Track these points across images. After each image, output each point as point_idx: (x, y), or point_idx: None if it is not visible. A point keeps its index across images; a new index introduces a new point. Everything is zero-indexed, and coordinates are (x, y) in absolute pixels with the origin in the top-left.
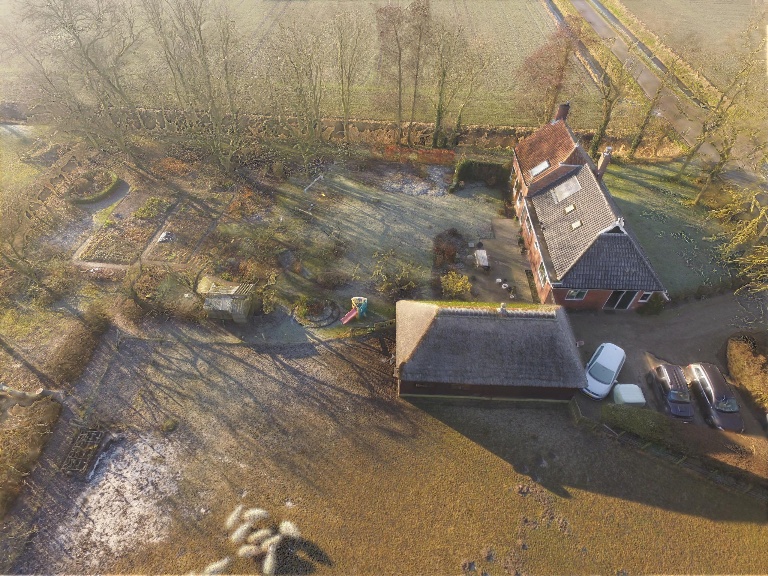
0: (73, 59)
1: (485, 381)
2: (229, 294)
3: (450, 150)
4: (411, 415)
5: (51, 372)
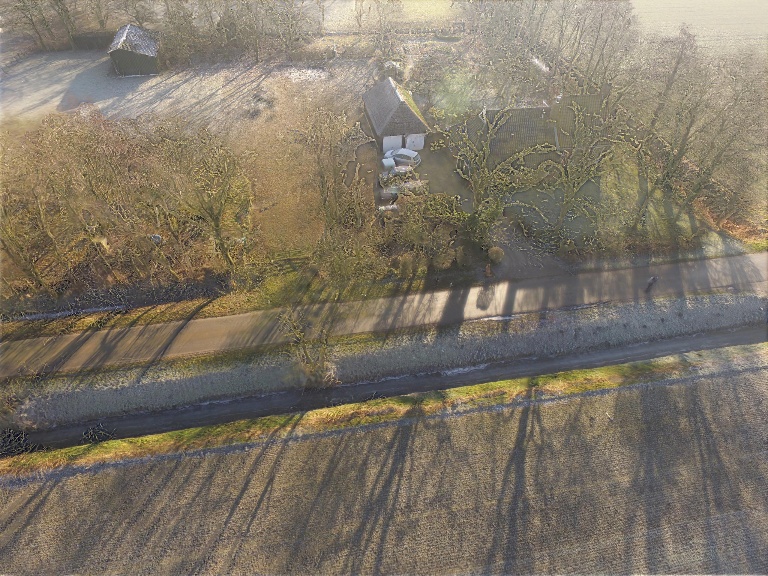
0: None
1: (369, 111)
2: None
3: None
4: None
5: None
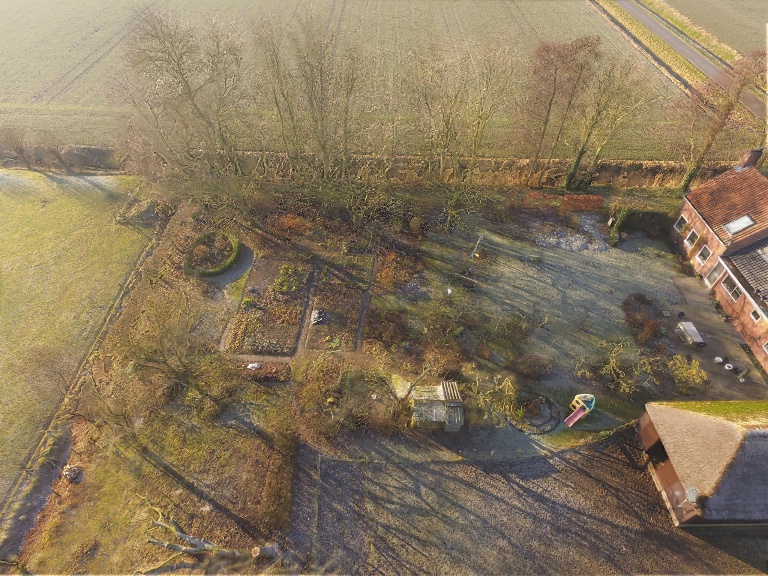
0: (178, 106)
1: None
2: (440, 400)
3: (587, 192)
4: (702, 553)
5: (251, 516)
